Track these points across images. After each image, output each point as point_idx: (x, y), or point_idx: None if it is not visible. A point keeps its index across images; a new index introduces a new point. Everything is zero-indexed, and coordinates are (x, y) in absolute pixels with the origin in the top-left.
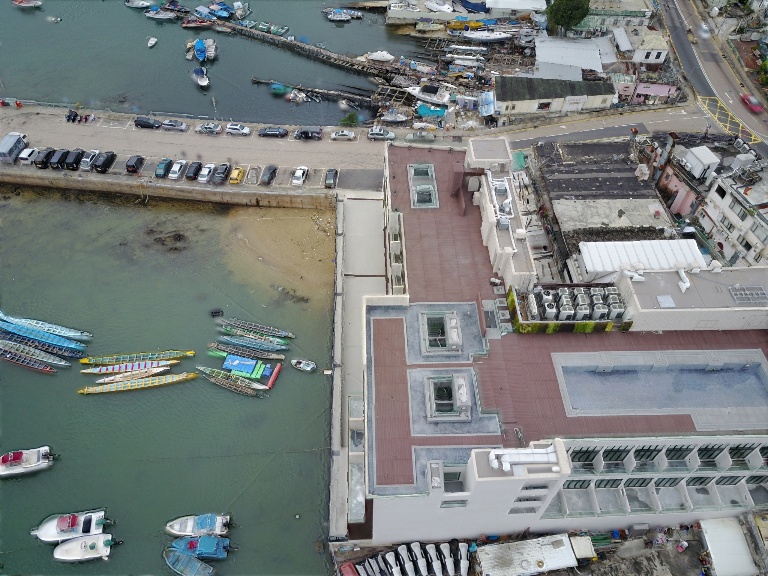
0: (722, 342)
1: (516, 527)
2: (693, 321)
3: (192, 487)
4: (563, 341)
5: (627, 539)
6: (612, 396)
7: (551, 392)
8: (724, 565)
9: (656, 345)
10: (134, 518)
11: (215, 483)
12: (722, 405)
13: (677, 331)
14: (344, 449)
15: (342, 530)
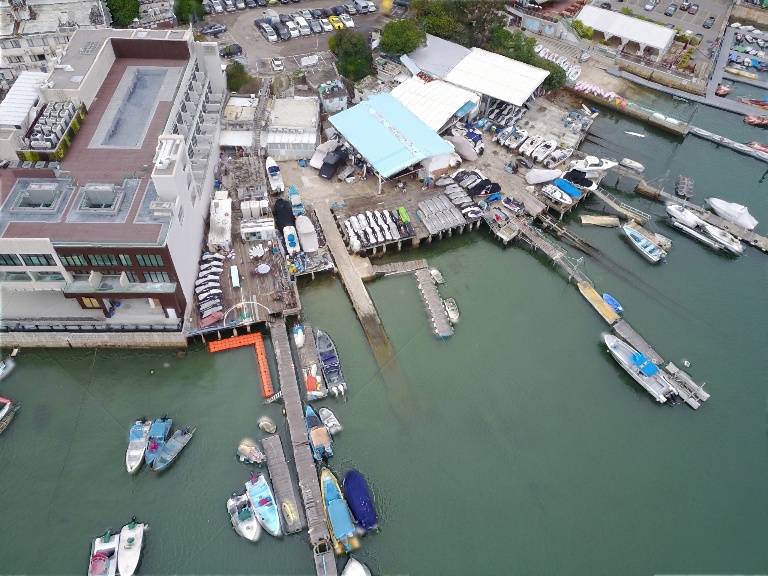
0: (116, 77)
1: (201, 221)
2: (96, 79)
3: (96, 463)
4: (80, 141)
5: (221, 182)
6: (133, 132)
7: (119, 153)
8: (245, 142)
9: (105, 103)
10: (112, 513)
11: (98, 444)
12: (158, 92)
13: (98, 92)
14: (106, 320)
15: (175, 321)
